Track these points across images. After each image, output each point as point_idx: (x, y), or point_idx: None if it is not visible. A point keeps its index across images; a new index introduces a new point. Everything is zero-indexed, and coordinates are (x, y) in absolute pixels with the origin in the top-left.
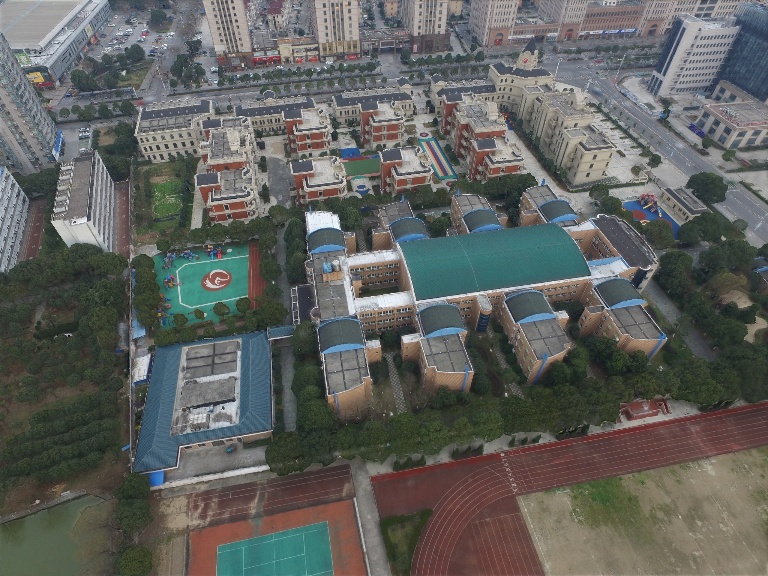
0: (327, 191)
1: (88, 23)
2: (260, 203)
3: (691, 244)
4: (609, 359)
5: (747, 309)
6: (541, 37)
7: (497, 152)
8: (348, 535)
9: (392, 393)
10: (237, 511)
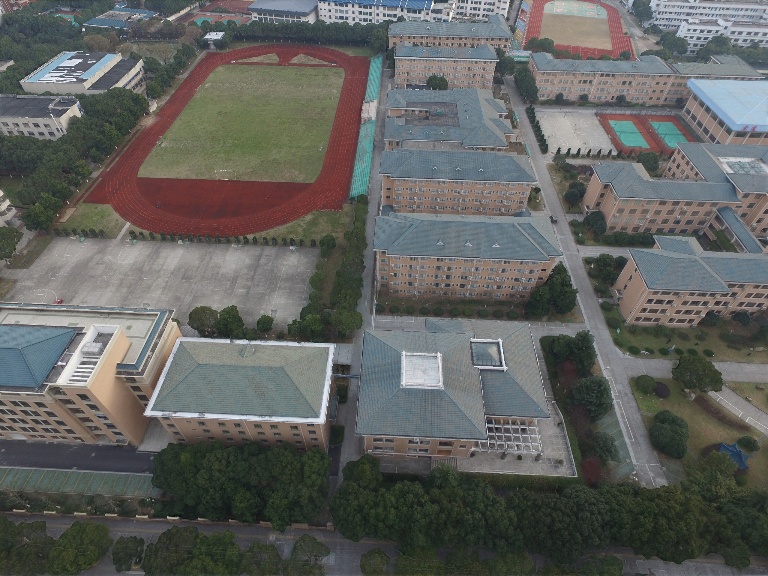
0: None
1: None
2: None
3: None
4: None
5: None
6: None
7: None
8: None
9: None
10: None
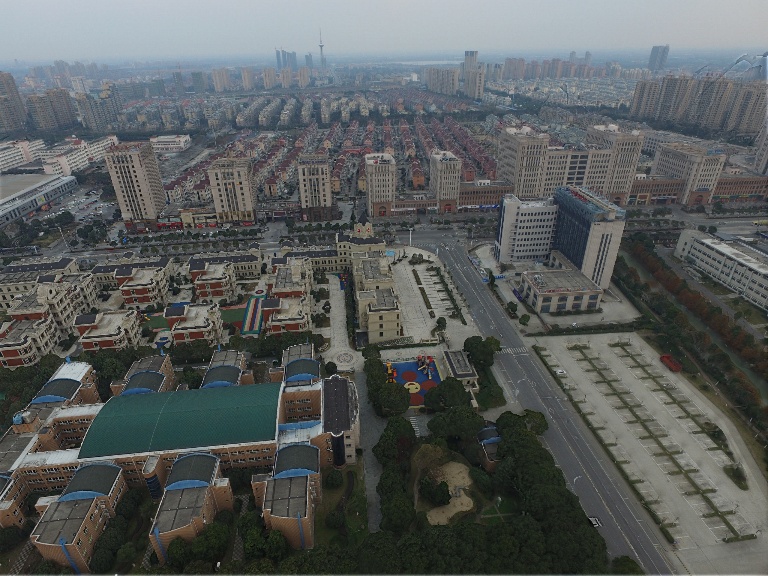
0: (102, 342)
1: (42, 195)
2: (58, 351)
3: (435, 409)
4: None
5: (438, 487)
6: (425, 210)
7: (283, 311)
8: None
9: (12, 565)
10: None
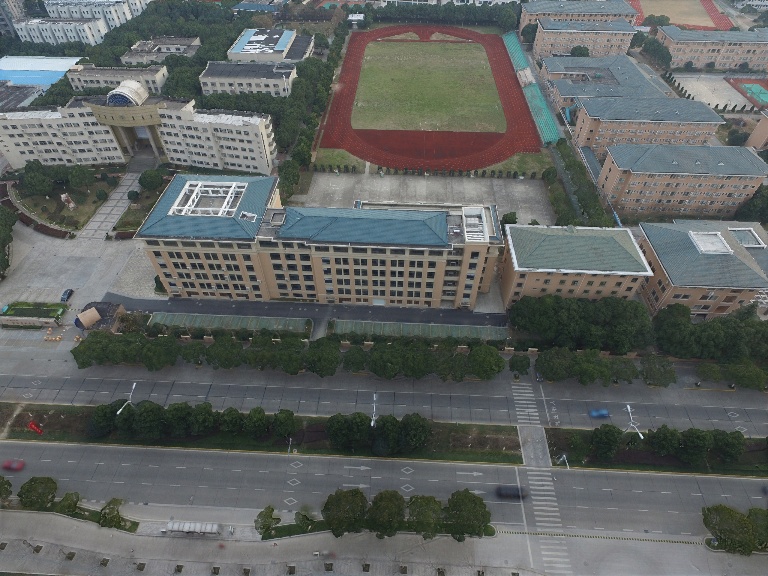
0: None
1: None
2: None
3: None
4: None
5: None
6: None
7: None
8: (333, 1)
9: None
10: None
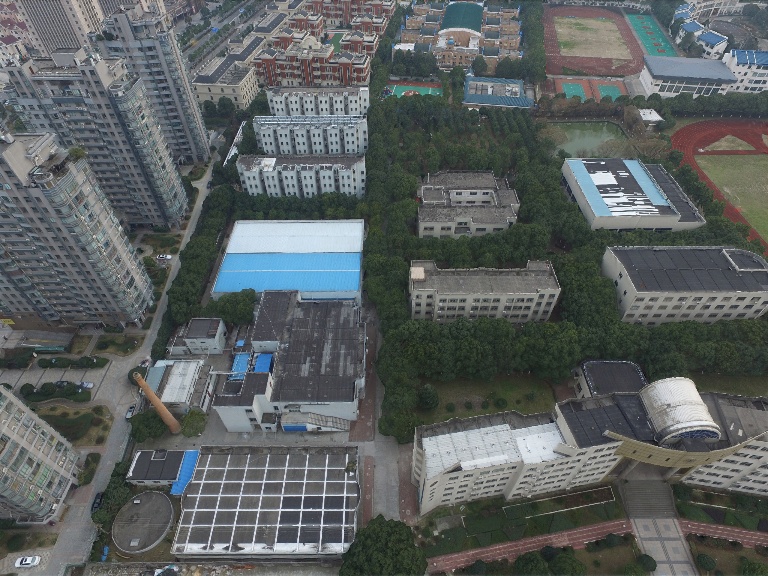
0: (376, 42)
1: None
2: None
3: None
4: None
5: (505, 2)
6: None
7: None
8: (568, 80)
9: None
10: (553, 97)
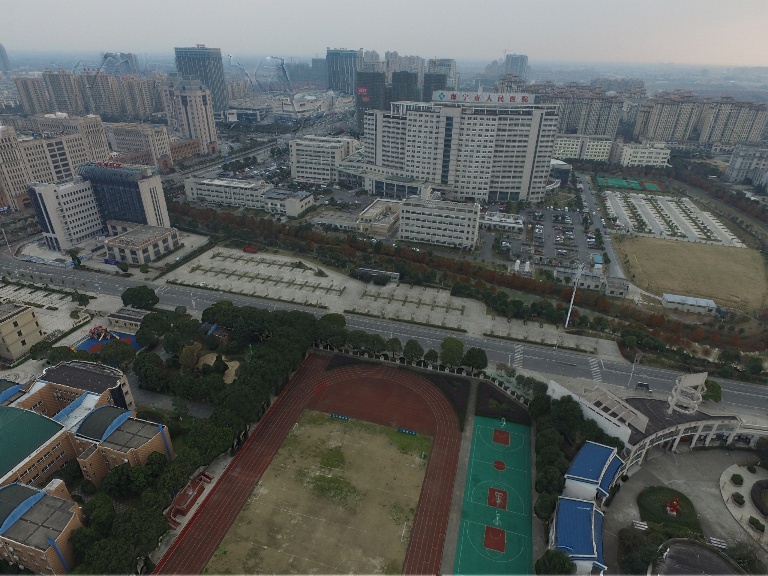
0: None
1: None
2: None
3: (153, 344)
4: (131, 483)
5: (216, 362)
6: None
7: None
8: None
9: None
10: None
